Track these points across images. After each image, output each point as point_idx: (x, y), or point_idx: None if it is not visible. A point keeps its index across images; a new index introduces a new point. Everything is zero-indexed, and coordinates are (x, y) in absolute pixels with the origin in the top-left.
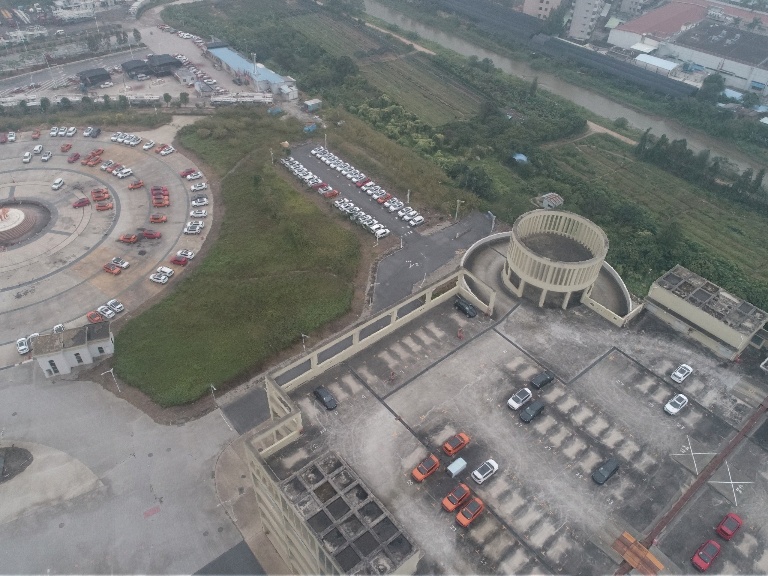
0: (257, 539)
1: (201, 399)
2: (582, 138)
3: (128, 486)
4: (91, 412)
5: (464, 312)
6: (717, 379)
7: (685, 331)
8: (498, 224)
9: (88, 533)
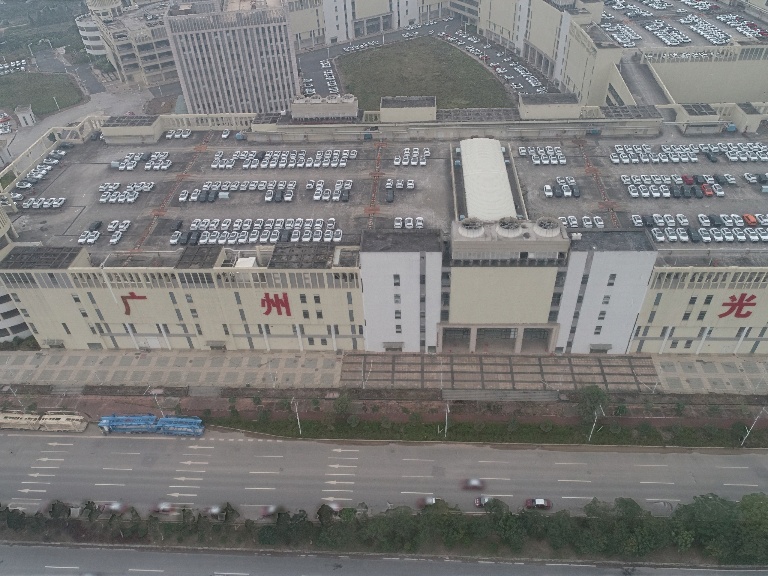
0: (150, 86)
1: (82, 97)
2: (3, 34)
3: (109, 105)
4: (65, 115)
5: (109, 22)
6: (168, 2)
7: (149, 2)
8: (47, 50)
9: (121, 109)
